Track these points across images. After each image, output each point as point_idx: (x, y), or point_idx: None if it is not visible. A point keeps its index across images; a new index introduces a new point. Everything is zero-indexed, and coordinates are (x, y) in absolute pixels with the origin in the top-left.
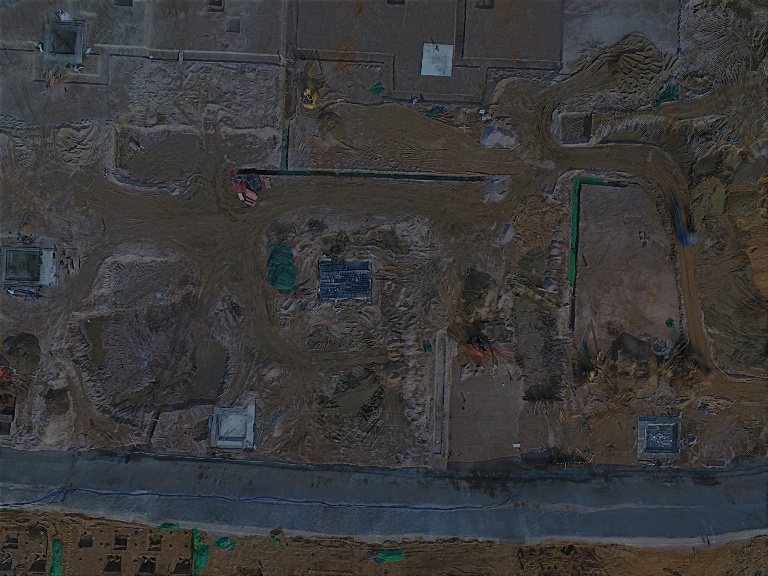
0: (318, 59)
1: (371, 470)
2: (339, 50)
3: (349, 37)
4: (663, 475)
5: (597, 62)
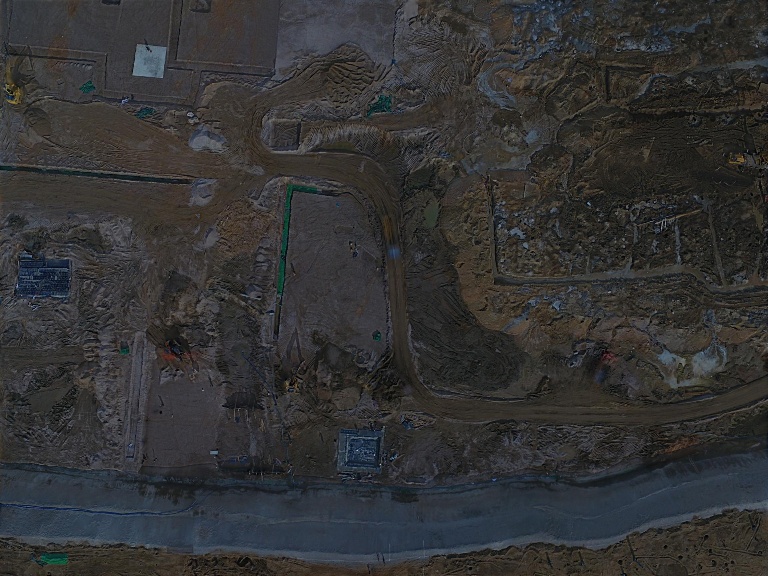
0: (29, 55)
1: (61, 471)
2: (51, 47)
3: (62, 35)
4: (363, 489)
5: (309, 70)
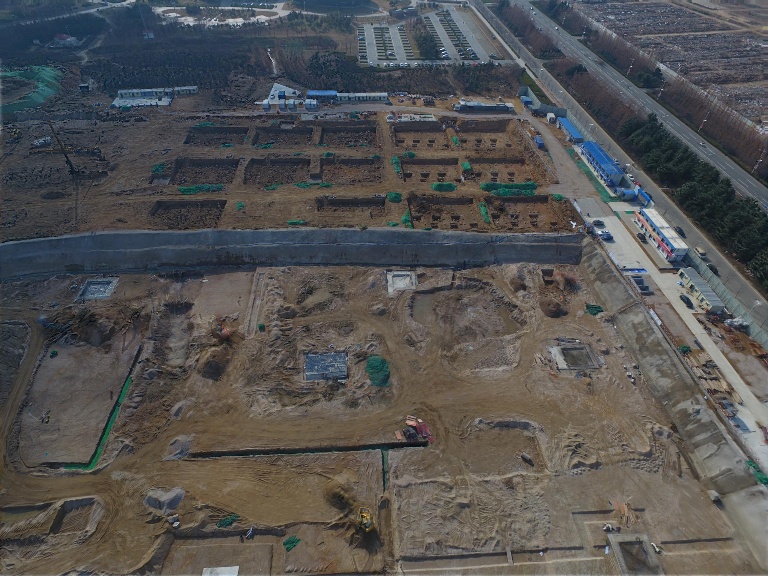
0: (359, 575)
1: (308, 265)
2: None
3: None
4: (104, 271)
5: None
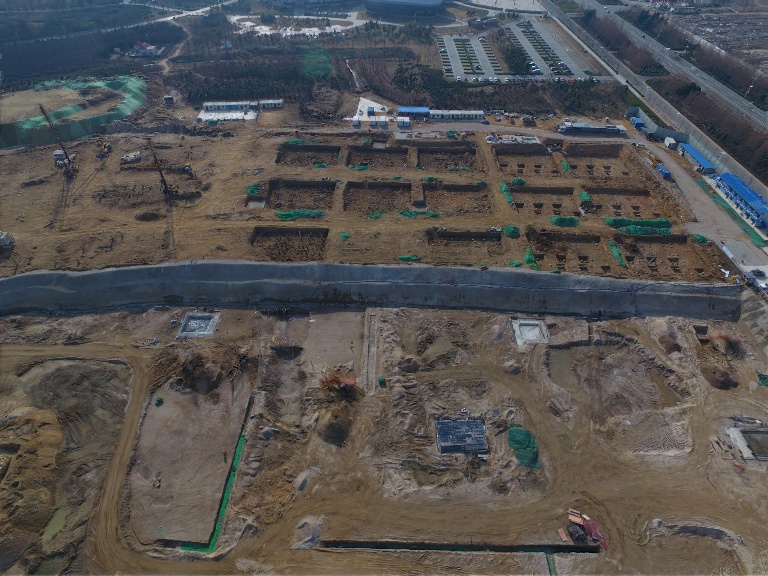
0: None
1: (422, 307)
2: None
3: None
4: (204, 304)
5: None
